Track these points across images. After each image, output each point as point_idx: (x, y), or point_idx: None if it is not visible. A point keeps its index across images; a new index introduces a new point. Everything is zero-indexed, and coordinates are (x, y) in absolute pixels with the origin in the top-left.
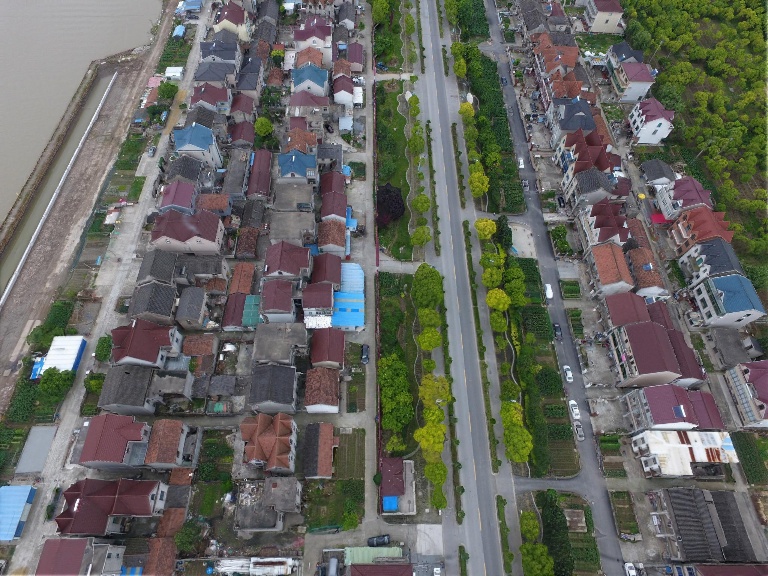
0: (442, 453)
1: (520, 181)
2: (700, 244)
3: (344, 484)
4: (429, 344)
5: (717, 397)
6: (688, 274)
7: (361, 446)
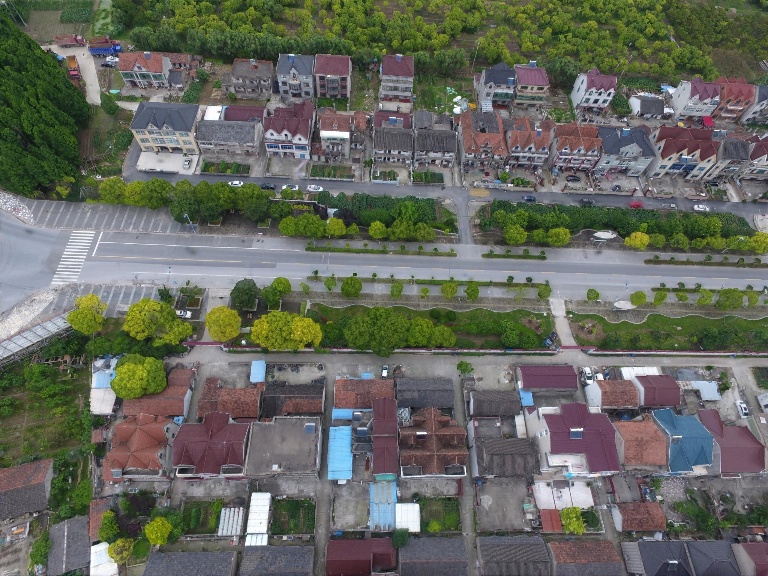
0: None
1: (695, 212)
2: (763, 100)
3: None
4: None
5: None
6: (765, 119)
7: None
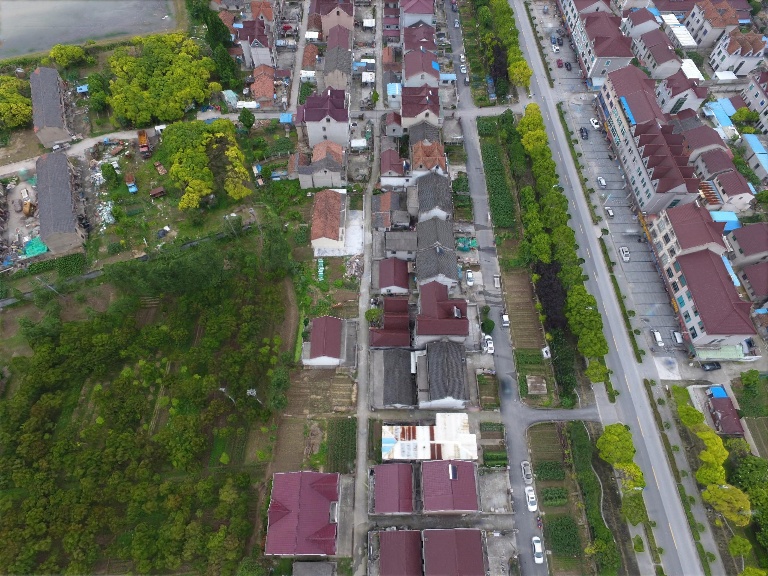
0: (677, 443)
1: None
2: None
3: (763, 412)
4: (759, 574)
5: (349, 520)
6: None
7: (762, 450)
